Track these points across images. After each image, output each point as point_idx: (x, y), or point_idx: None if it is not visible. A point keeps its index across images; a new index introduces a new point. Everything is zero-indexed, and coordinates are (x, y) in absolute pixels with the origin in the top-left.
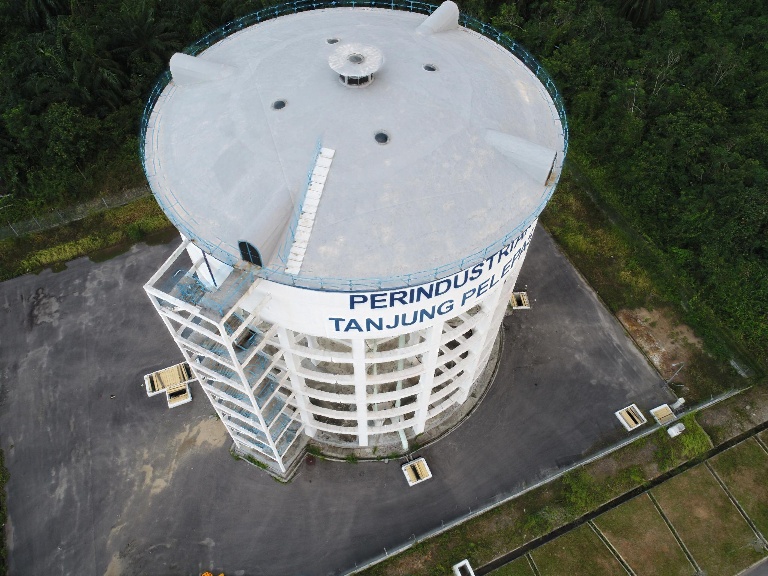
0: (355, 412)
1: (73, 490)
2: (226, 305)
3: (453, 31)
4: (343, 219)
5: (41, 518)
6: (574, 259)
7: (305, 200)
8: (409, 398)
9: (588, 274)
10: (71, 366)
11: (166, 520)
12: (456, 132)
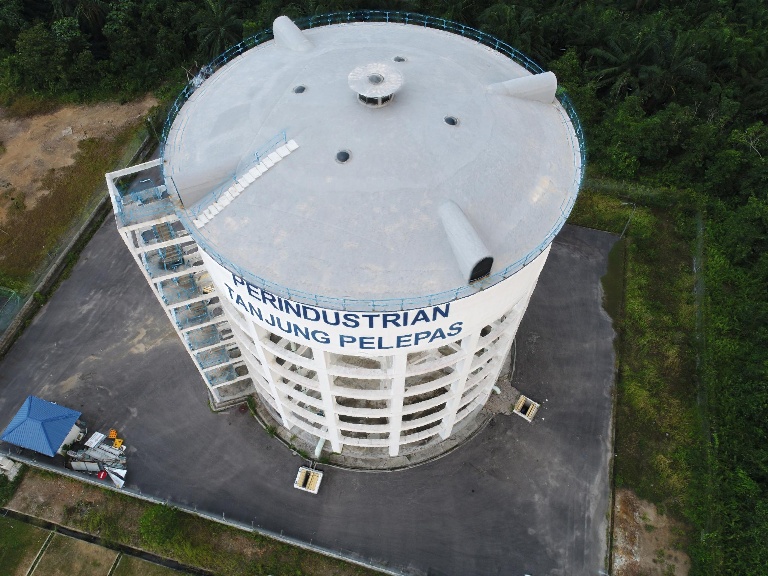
0: None
1: (93, 312)
2: (136, 219)
3: (540, 103)
4: (259, 205)
5: (63, 317)
6: (619, 409)
7: (246, 174)
8: (354, 418)
9: (622, 432)
10: None
11: (123, 375)
12: (414, 187)
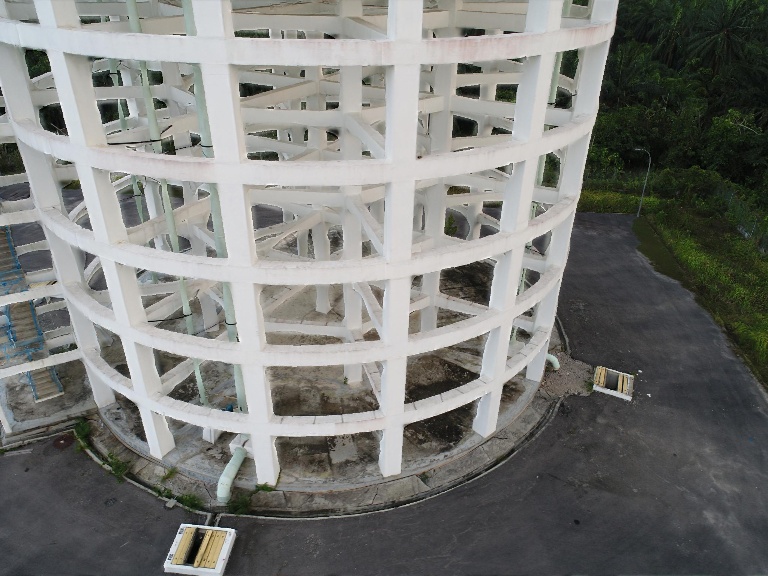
0: None
1: None
2: None
3: None
4: None
5: None
6: (762, 369)
7: None
8: None
9: None
10: None
11: None
12: None
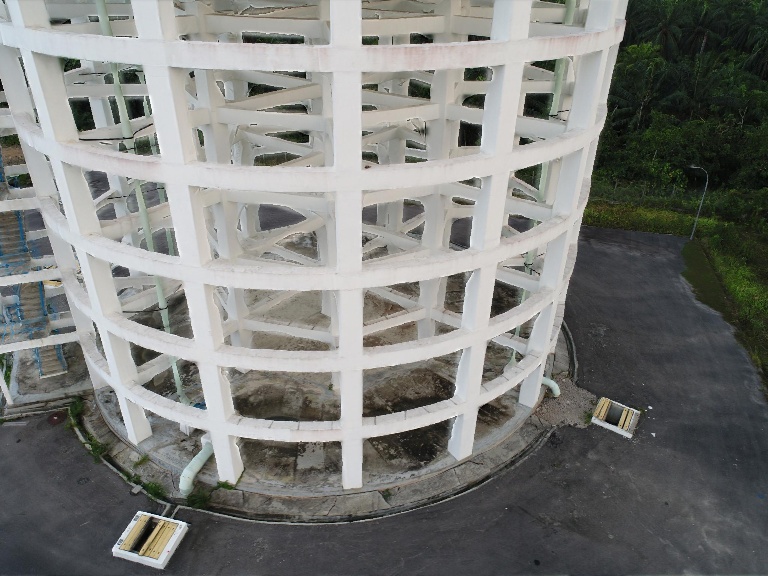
0: None
1: None
2: None
3: None
4: None
5: None
6: None
7: None
8: None
9: None
10: (28, 226)
11: None
12: None
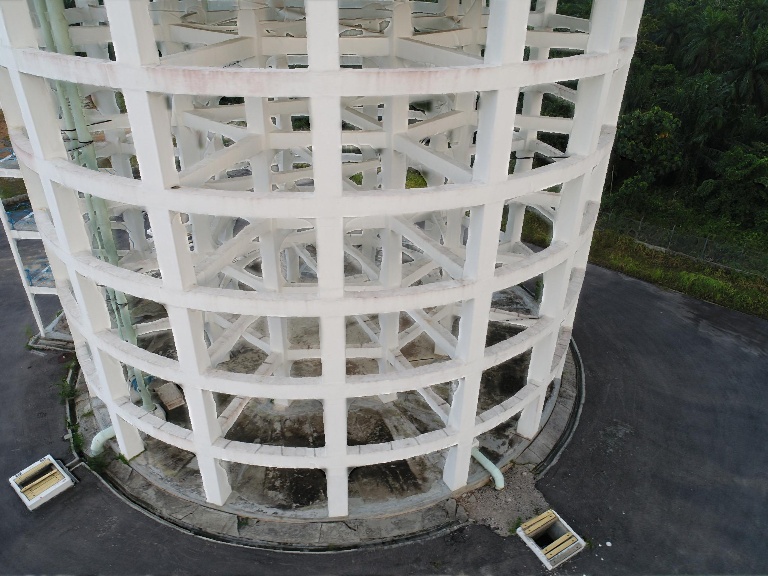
0: None
1: None
2: None
3: None
4: None
5: None
6: None
7: None
8: None
9: None
10: None
11: None
12: None
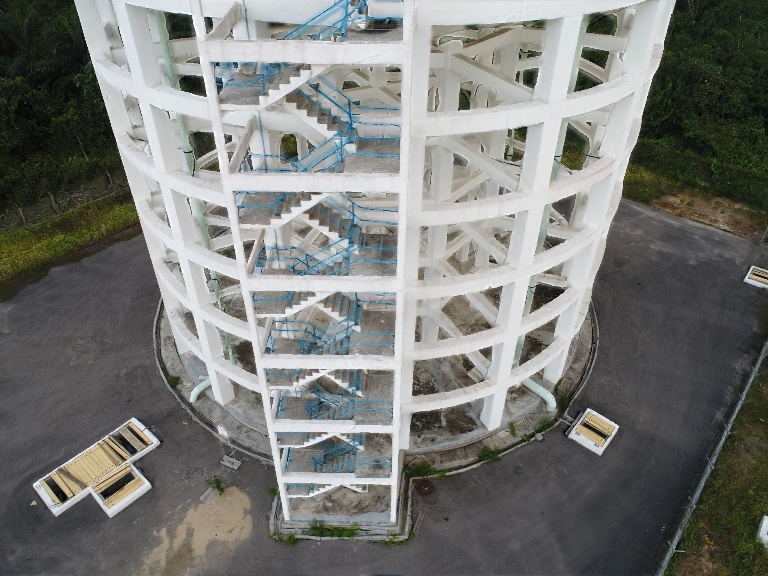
0: (497, 327)
1: None
2: None
3: None
4: None
5: None
6: None
7: None
8: None
9: None
10: None
11: None
12: None
